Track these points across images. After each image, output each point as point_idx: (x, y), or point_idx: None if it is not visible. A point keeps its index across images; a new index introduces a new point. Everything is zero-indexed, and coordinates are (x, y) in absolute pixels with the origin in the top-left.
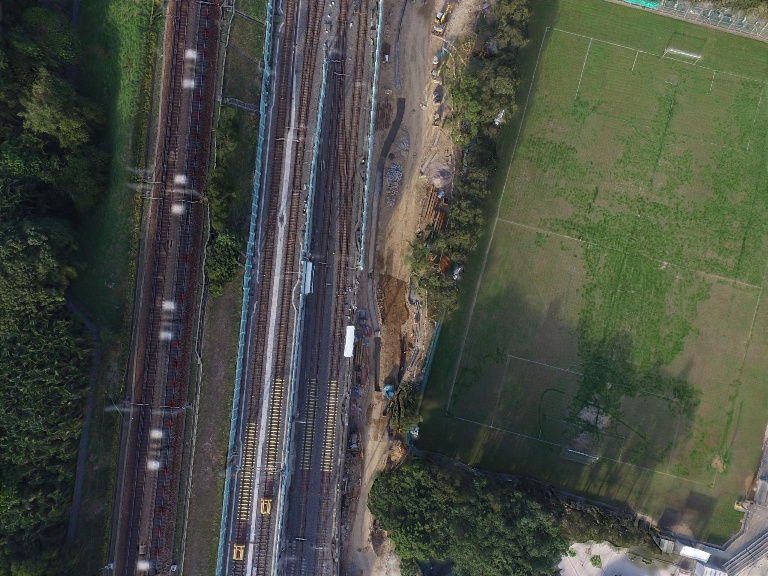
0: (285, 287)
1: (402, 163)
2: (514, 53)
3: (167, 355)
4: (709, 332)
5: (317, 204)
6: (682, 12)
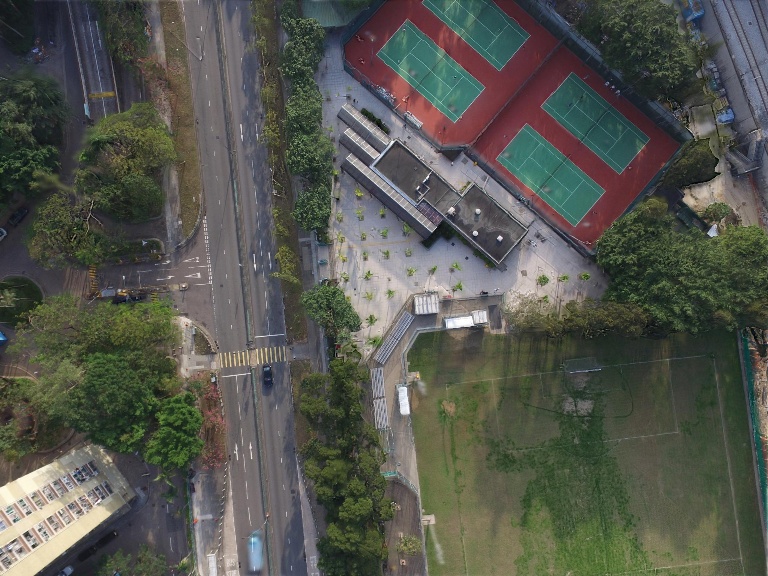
0: None
1: None
2: None
3: None
4: (503, 529)
5: None
6: None
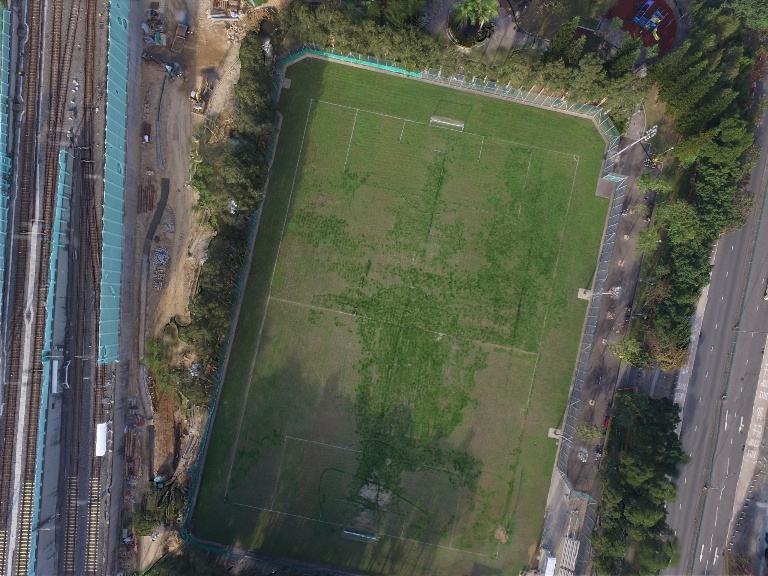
0: (34, 386)
1: (168, 245)
2: (252, 137)
3: None
4: (487, 402)
5: (70, 296)
6: (447, 79)
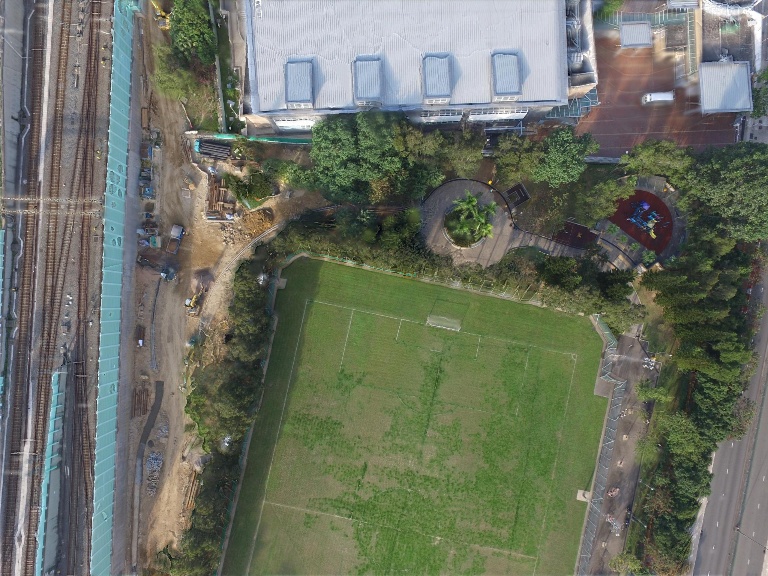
0: None
1: (162, 450)
2: (246, 363)
3: None
4: None
5: (62, 513)
6: (443, 278)
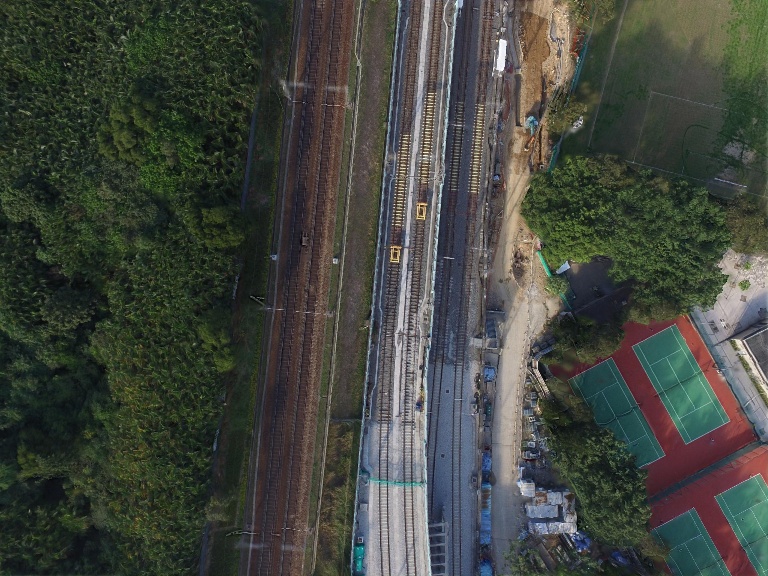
0: (436, 4)
1: None
2: None
3: (328, 55)
4: None
5: None
6: None
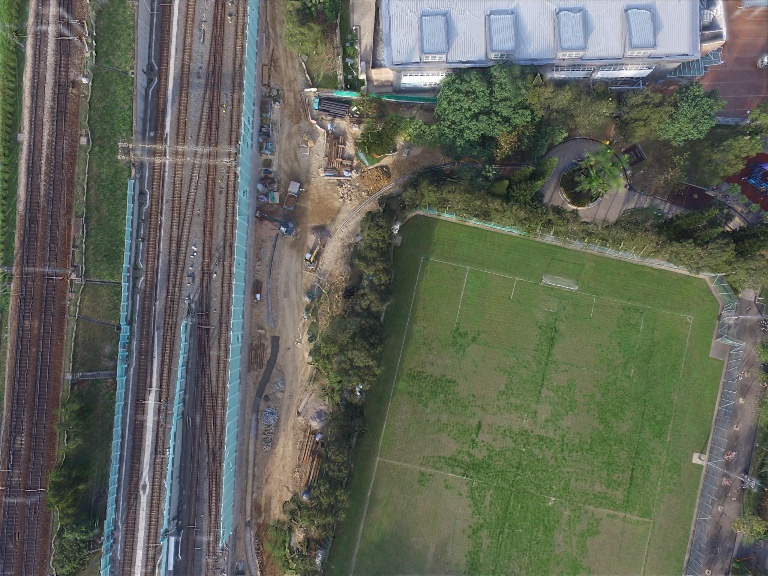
0: (148, 561)
1: (277, 405)
2: (376, 314)
3: None
4: (600, 570)
5: (184, 464)
6: (559, 238)
